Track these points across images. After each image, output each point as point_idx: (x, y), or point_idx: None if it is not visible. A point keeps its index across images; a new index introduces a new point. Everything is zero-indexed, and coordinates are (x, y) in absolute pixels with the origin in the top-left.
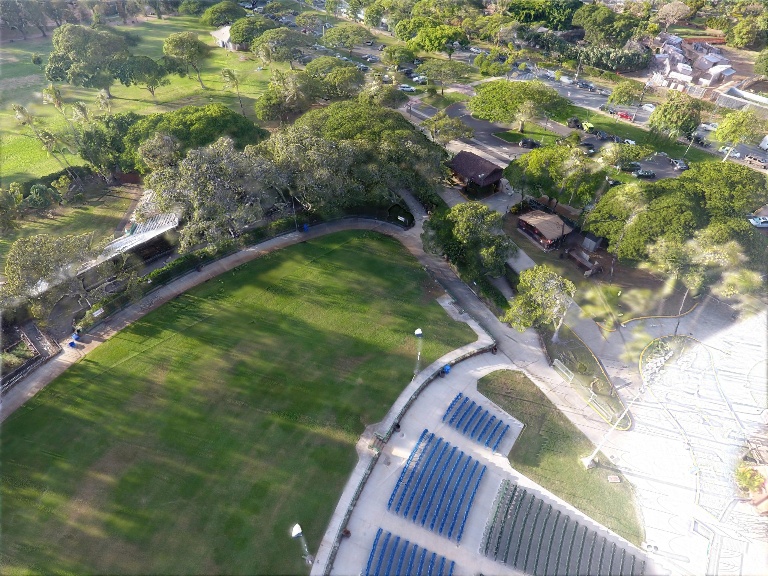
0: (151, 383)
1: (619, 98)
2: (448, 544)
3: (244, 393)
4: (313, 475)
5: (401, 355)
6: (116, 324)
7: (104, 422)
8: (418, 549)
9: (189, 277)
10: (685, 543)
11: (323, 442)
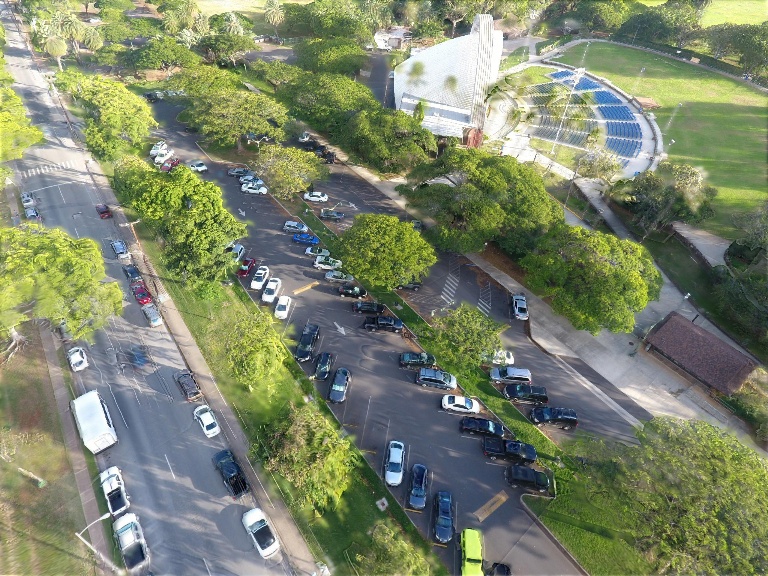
0: None
1: (414, 552)
2: None
3: None
4: None
5: None
6: None
7: None
8: None
9: None
10: (515, 137)
11: None
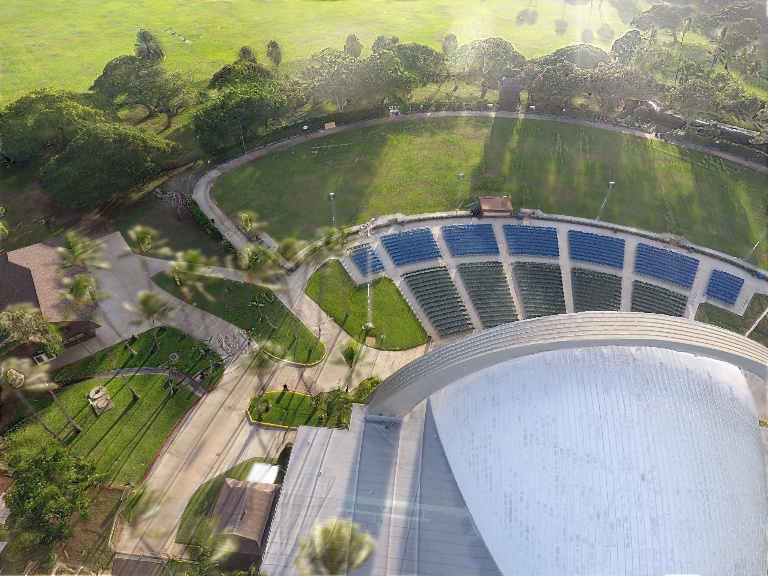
0: (653, 160)
1: None
2: (631, 268)
3: (670, 189)
4: (639, 217)
5: (754, 252)
6: (679, 143)
7: (624, 152)
8: (622, 255)
9: (737, 158)
10: None
11: (660, 220)
